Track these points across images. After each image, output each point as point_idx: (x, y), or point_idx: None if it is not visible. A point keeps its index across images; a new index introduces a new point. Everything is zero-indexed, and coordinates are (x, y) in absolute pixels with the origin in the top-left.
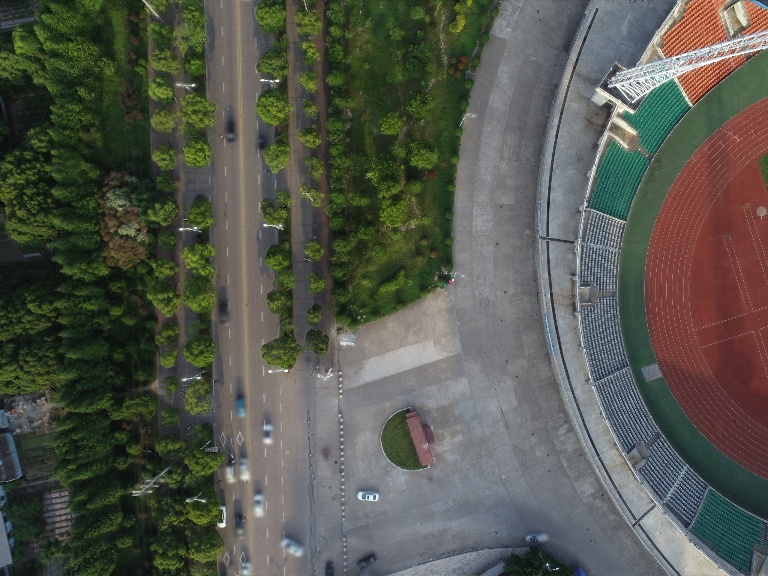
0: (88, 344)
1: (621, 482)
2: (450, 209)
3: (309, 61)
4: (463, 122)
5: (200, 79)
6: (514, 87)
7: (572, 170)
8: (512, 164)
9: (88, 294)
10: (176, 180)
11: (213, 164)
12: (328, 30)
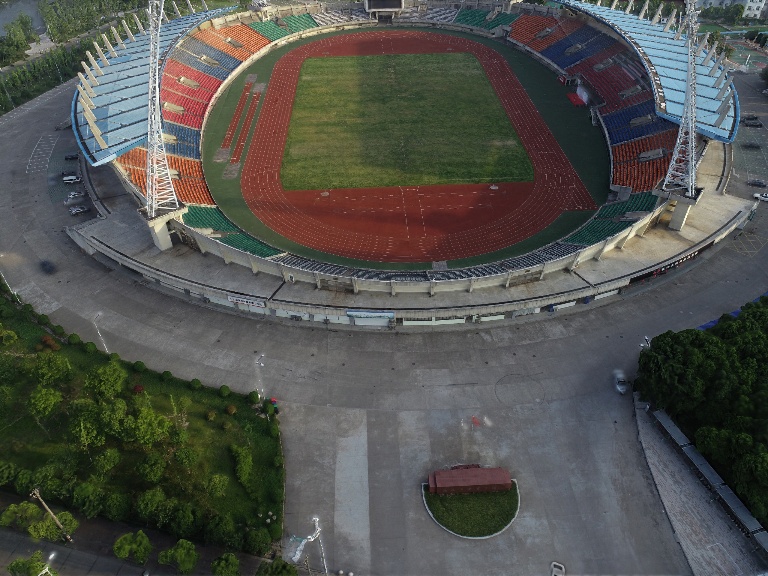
0: None
1: (546, 290)
2: None
3: None
4: None
5: None
6: (110, 310)
7: (215, 272)
8: (182, 325)
9: None
10: None
11: None
12: None
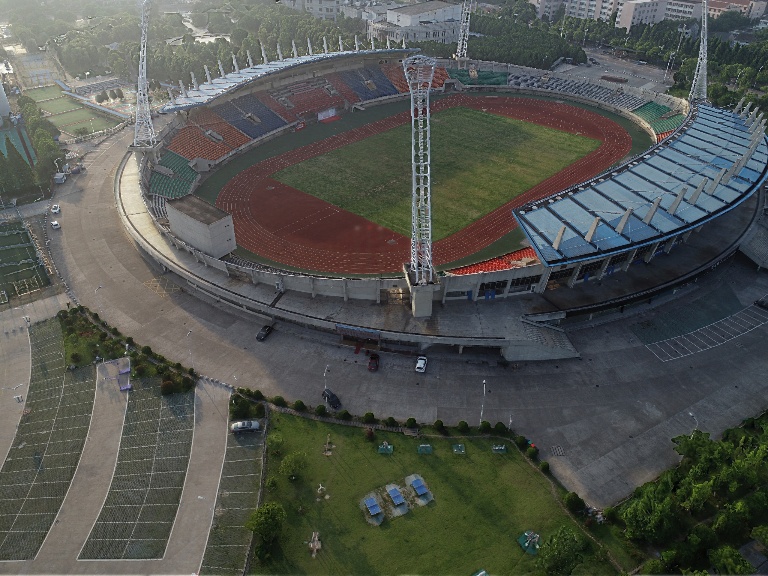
0: (740, 57)
1: None
2: None
3: None
4: None
5: None
6: None
7: None
8: None
9: (759, 62)
10: None
11: None
12: None
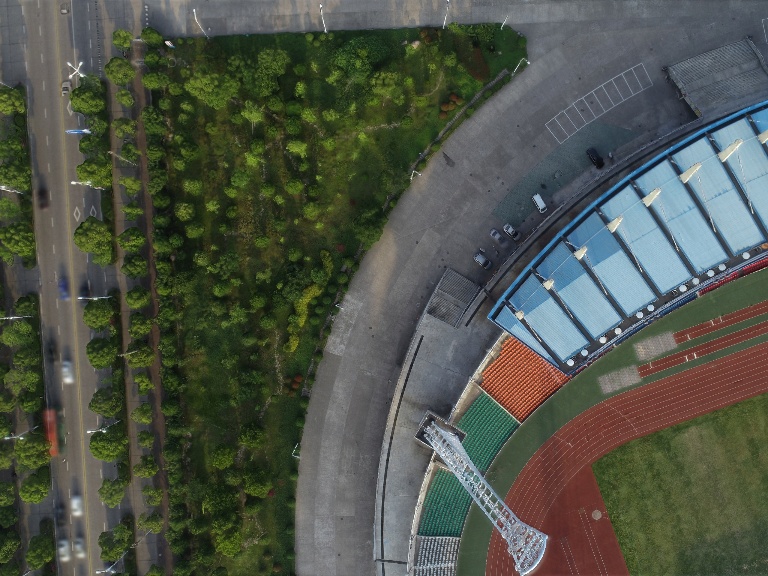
0: None
1: None
2: (291, 524)
3: (143, 393)
4: (301, 438)
5: (40, 406)
6: (350, 402)
7: (404, 493)
8: (351, 477)
9: None
10: (21, 503)
11: (57, 487)
12: (162, 359)
